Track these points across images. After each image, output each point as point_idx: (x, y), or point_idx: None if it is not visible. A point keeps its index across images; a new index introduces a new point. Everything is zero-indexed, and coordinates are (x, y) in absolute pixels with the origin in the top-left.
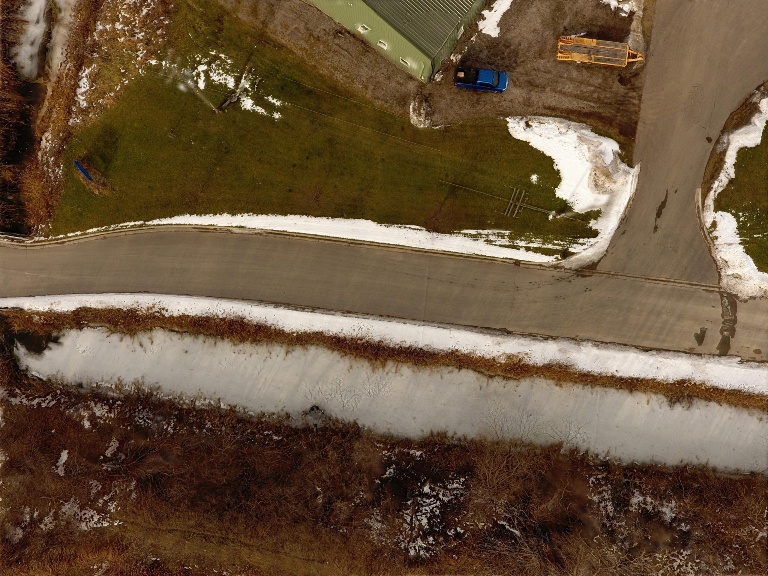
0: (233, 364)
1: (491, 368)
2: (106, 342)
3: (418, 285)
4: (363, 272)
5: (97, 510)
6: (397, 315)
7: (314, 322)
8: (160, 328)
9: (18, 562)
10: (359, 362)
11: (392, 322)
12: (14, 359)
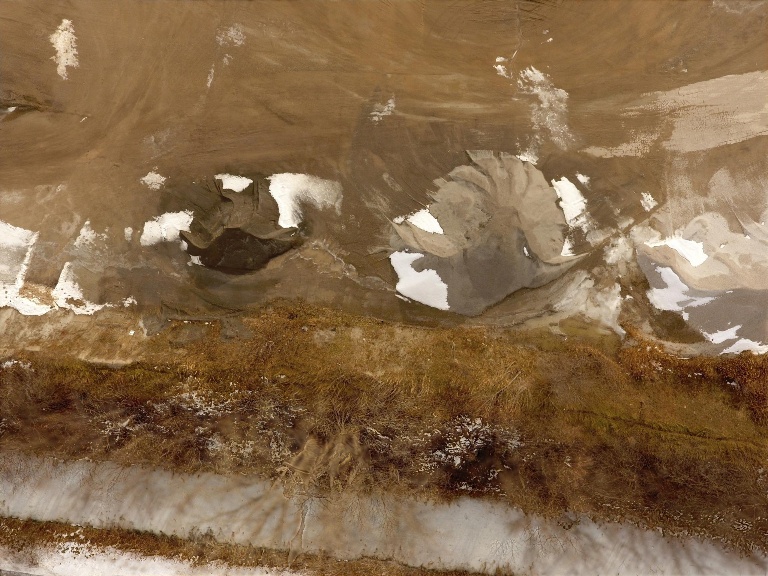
0: (650, 571)
1: (391, 570)
2: None
3: None
4: None
5: None
6: None
7: None
8: None
9: None
10: (523, 574)
11: None
12: None
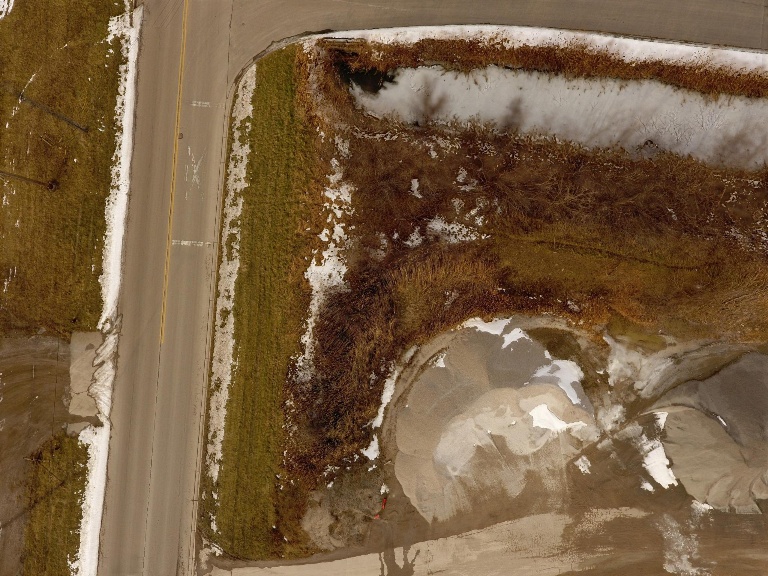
0: (567, 100)
1: None
2: (441, 80)
3: (755, 13)
4: (701, 1)
5: (465, 223)
6: (734, 44)
7: (655, 50)
8: (494, 65)
9: (405, 263)
10: (692, 95)
11: (731, 50)
12: (351, 98)
